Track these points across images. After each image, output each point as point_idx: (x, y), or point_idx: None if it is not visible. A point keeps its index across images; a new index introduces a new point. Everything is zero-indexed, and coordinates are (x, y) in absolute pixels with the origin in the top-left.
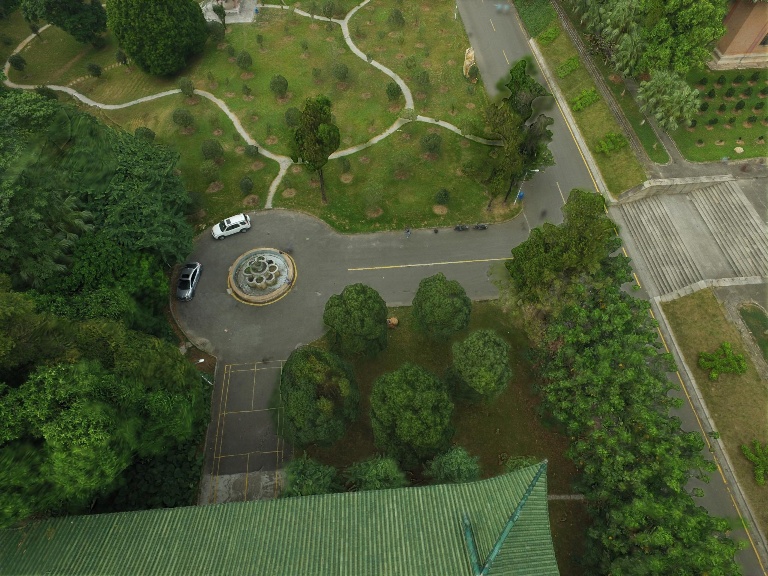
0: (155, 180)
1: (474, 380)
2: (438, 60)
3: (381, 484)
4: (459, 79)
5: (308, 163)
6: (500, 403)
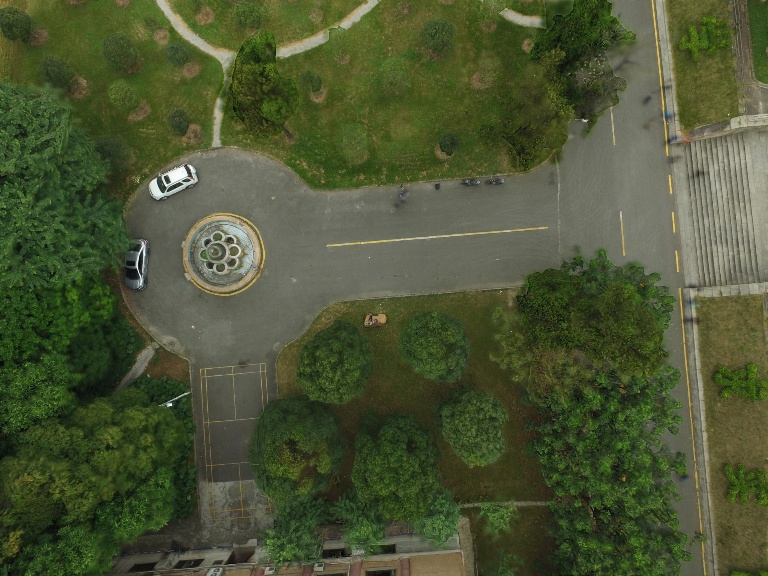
0: (46, 172)
1: (463, 460)
2: None
3: None
4: None
5: None
6: None
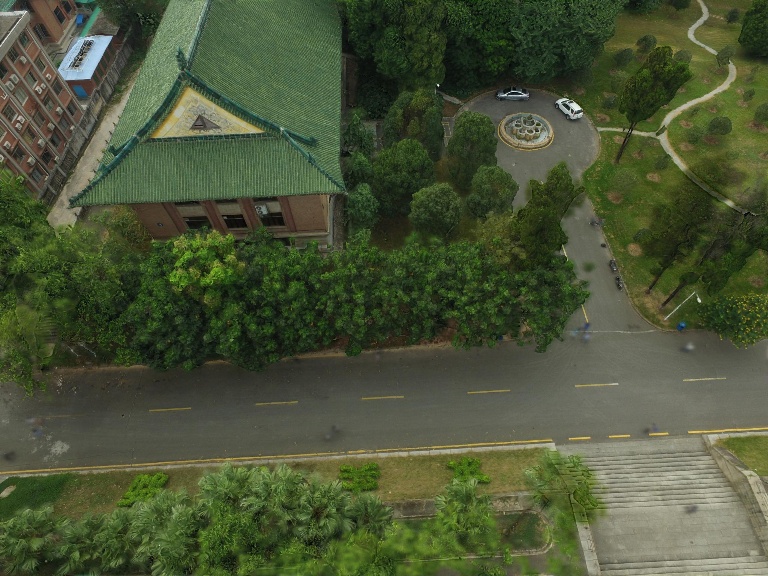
0: (573, 25)
1: None
2: None
3: None
4: None
5: None
6: None
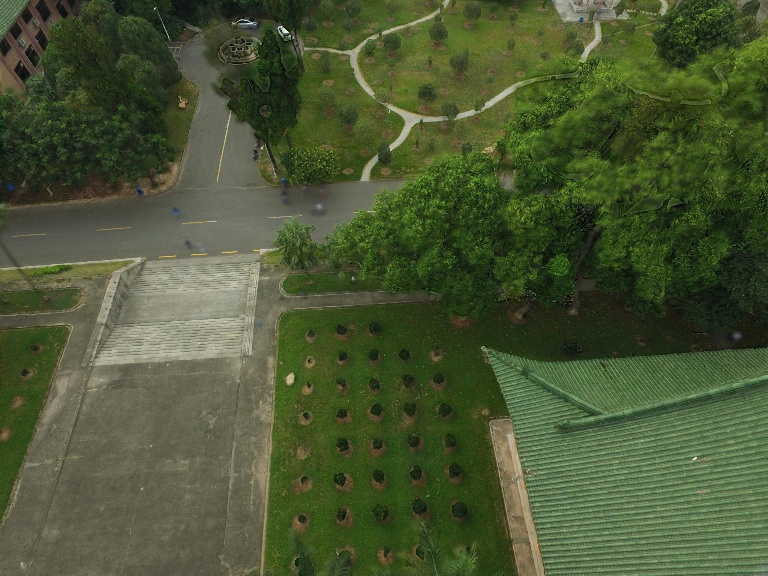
0: None
1: None
2: None
3: None
4: None
5: None
6: None
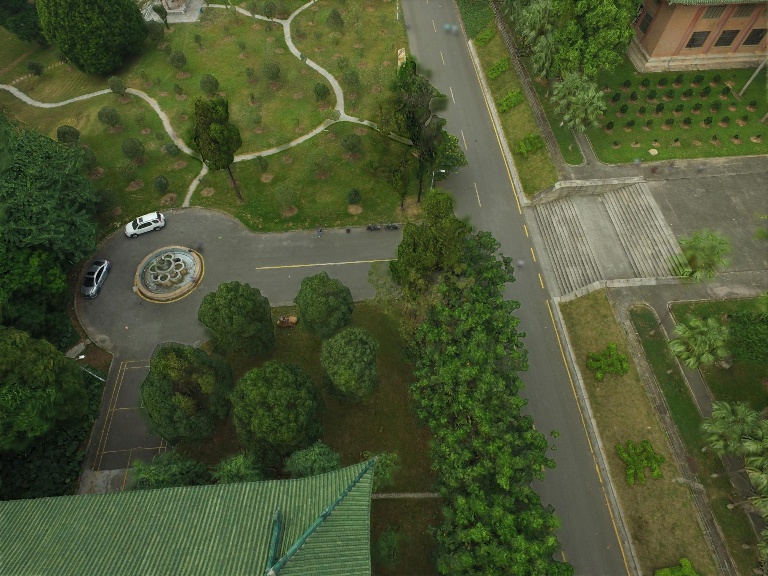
0: (53, 178)
1: (335, 378)
2: (374, 61)
3: (239, 480)
4: (392, 80)
5: (209, 162)
6: (387, 401)
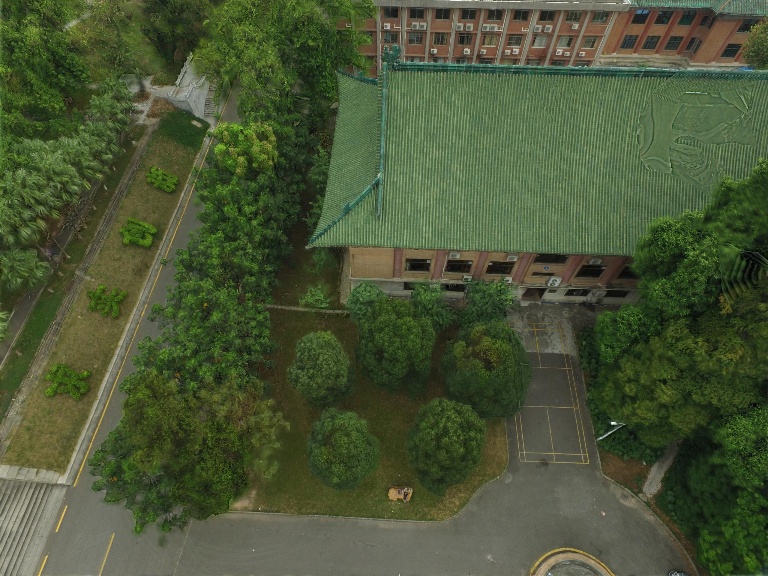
0: None
1: None
2: None
3: None
4: None
5: None
6: None
